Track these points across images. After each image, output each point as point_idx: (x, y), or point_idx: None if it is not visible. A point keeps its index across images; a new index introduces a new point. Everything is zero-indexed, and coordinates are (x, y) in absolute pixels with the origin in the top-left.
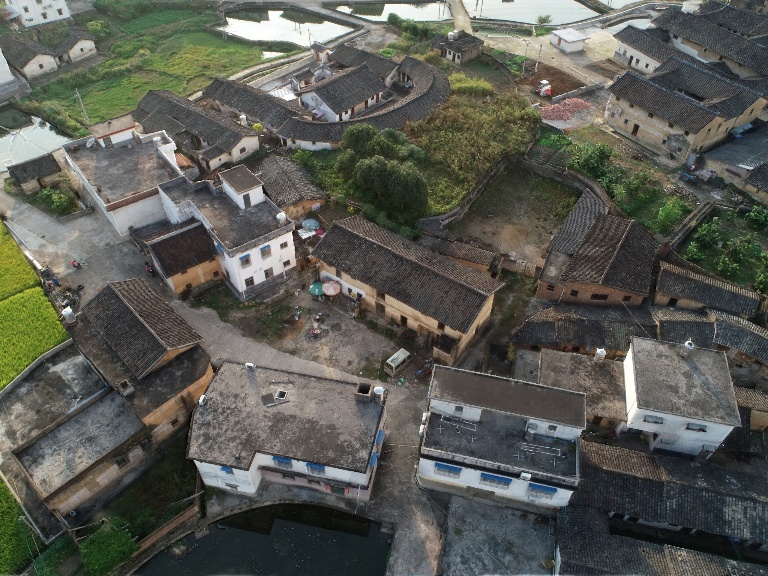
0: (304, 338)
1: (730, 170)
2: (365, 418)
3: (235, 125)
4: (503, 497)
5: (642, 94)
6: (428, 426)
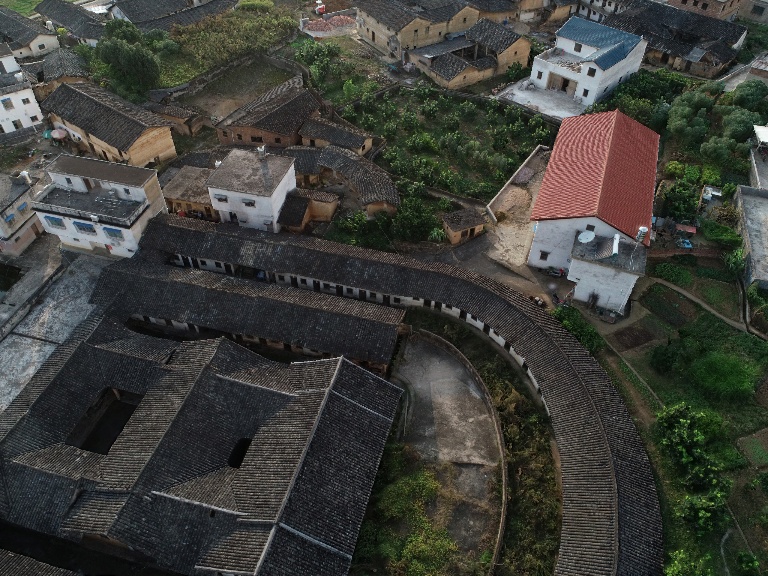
0: (29, 167)
1: (421, 61)
2: (12, 193)
3: (39, 27)
4: (116, 255)
5: (373, 4)
6: (49, 194)
